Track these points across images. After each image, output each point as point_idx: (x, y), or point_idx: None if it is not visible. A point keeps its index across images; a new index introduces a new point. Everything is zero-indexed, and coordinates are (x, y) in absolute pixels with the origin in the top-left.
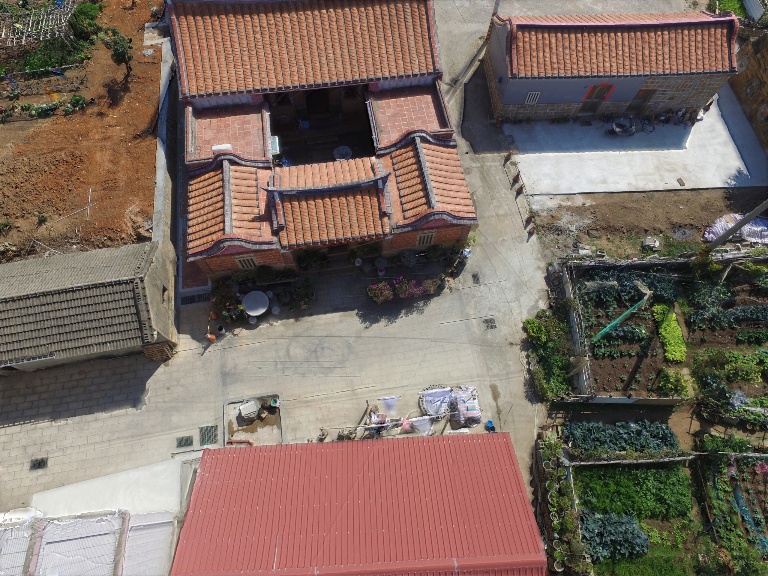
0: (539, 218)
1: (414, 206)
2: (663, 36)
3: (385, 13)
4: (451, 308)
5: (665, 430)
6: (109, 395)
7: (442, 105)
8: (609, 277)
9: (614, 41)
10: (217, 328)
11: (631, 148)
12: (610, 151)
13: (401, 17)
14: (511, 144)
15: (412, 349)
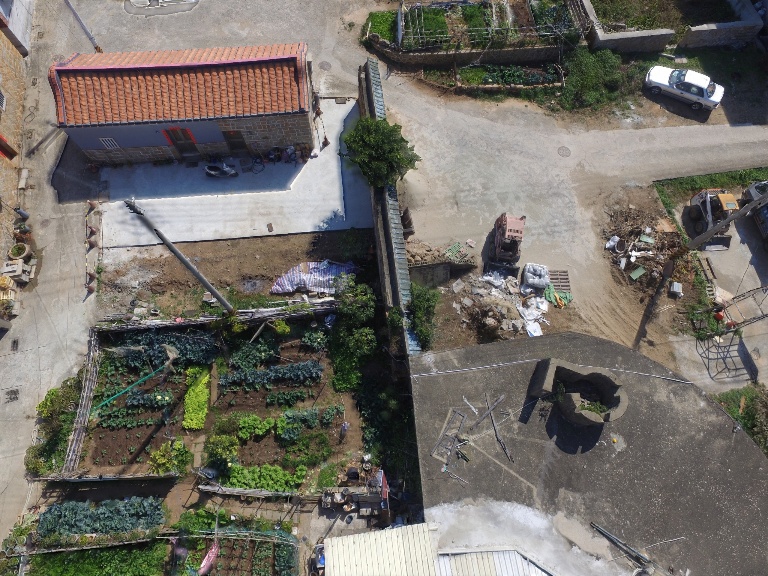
0: (104, 274)
1: None
2: (226, 76)
3: None
4: None
5: (145, 508)
6: None
7: None
8: (141, 341)
9: (174, 83)
10: None
11: (231, 191)
12: (208, 195)
13: None
14: (103, 191)
15: None
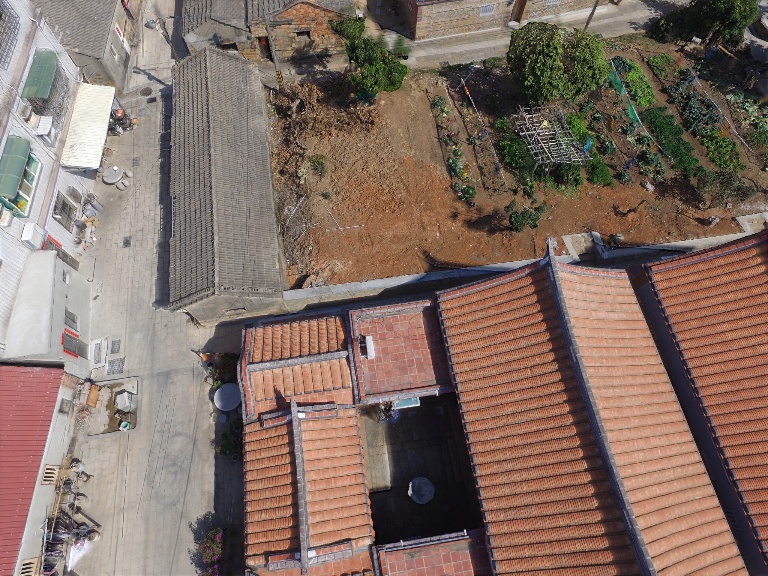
0: None
1: None
2: None
3: (603, 572)
4: None
5: None
6: None
7: None
8: None
9: None
10: (216, 361)
11: None
12: None
13: None
14: None
15: None
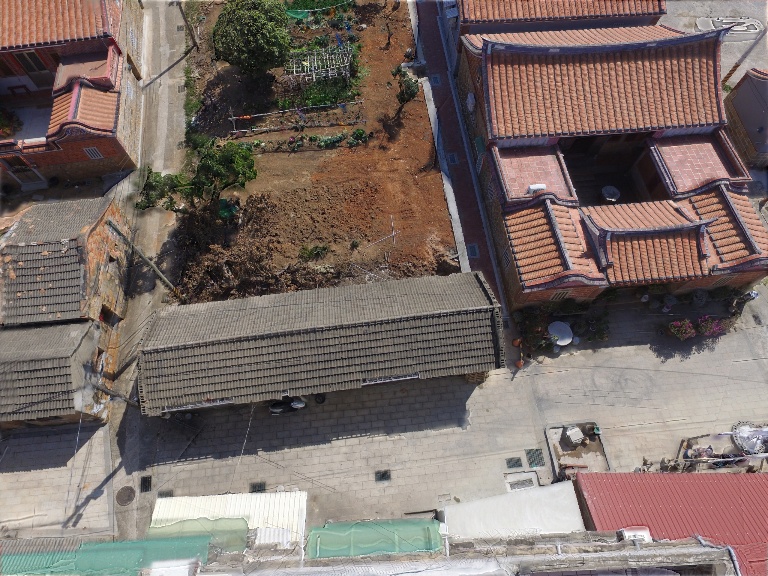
0: None
1: (731, 250)
2: None
3: (675, 67)
4: (740, 347)
5: None
6: (434, 414)
7: (732, 154)
8: None
9: None
10: None
11: None
12: None
13: (690, 71)
14: (761, 190)
15: (712, 385)
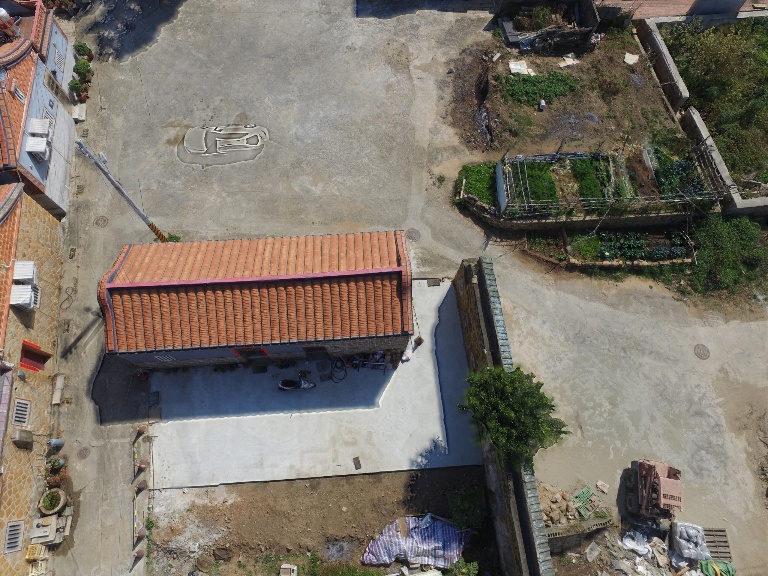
0: (156, 530)
1: None
2: (314, 291)
3: None
4: None
5: None
6: None
7: None
8: None
9: (249, 299)
10: None
11: (307, 408)
12: (280, 413)
13: None
14: (154, 406)
15: None
